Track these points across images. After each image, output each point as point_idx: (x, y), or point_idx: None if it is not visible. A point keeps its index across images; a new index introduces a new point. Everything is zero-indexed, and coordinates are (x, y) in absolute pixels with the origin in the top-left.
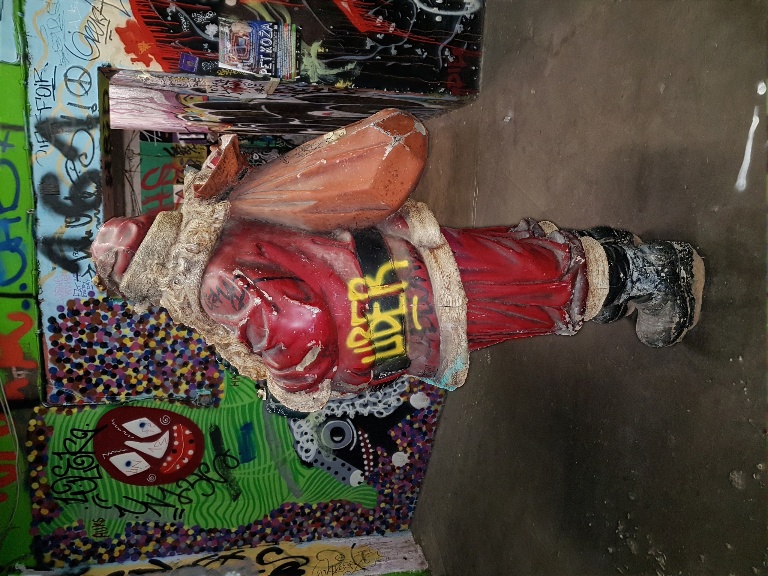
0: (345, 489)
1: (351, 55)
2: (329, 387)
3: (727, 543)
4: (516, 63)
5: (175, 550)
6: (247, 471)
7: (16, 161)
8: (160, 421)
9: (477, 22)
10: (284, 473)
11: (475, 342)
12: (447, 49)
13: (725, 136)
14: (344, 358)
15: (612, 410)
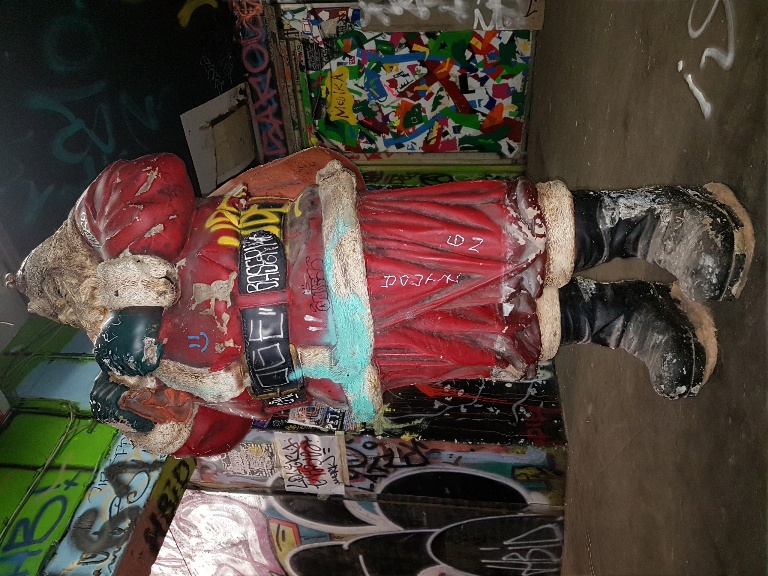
0: None
1: (418, 413)
2: (166, 263)
3: None
4: (579, 370)
5: None
6: None
7: (71, 498)
8: None
9: (550, 386)
10: None
11: (389, 258)
12: (522, 407)
13: (682, 120)
14: (199, 243)
15: (764, 502)
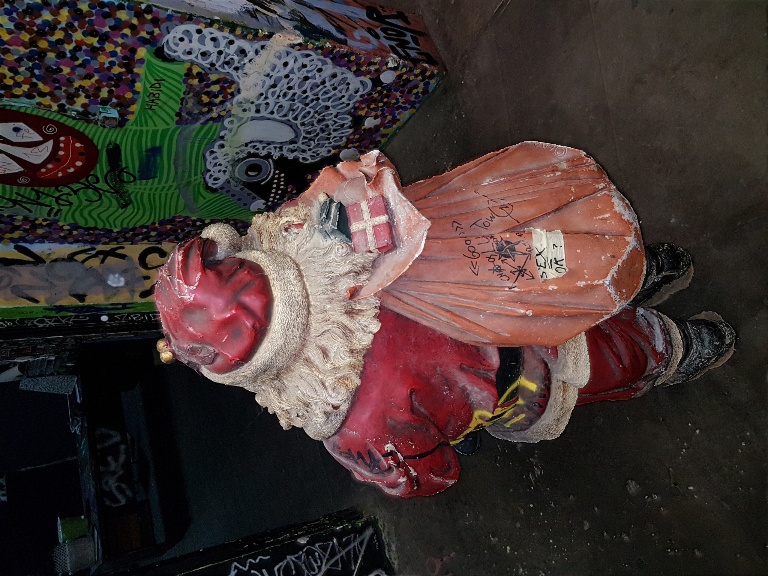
0: (243, 212)
1: None
2: None
3: (596, 507)
4: None
5: (45, 239)
6: (143, 187)
7: None
8: (42, 129)
9: None
10: (184, 193)
11: None
12: None
13: None
14: None
15: None
